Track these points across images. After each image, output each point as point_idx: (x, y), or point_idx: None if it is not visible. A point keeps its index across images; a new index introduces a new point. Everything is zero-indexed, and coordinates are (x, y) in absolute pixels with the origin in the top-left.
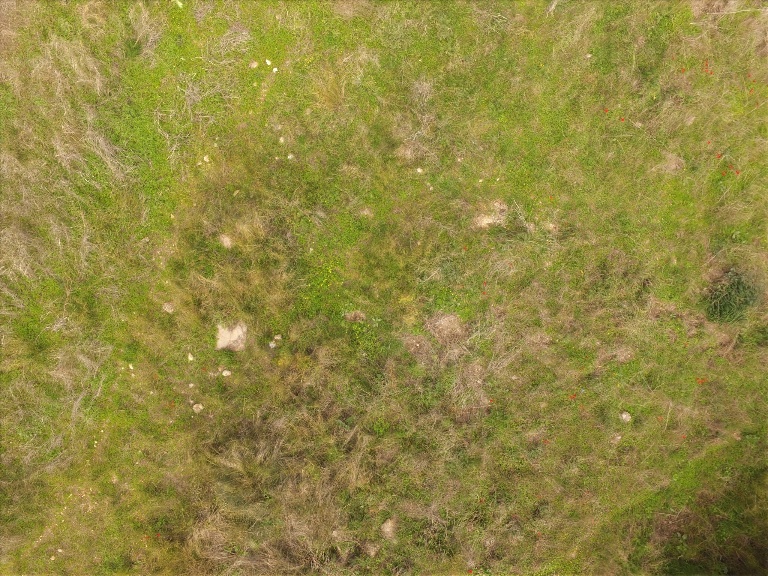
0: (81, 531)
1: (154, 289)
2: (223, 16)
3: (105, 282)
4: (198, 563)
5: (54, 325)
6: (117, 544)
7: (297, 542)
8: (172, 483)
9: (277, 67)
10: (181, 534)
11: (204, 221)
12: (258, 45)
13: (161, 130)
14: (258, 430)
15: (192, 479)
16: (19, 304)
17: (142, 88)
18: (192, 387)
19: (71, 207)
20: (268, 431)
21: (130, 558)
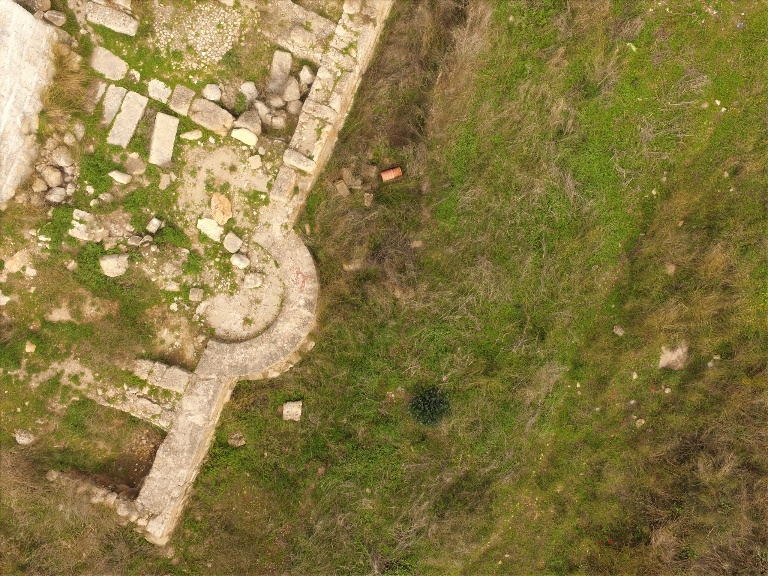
0: (528, 537)
1: (600, 313)
2: (680, 60)
3: (557, 306)
4: (665, 567)
5: (513, 347)
6: (561, 549)
7: (735, 547)
8: (613, 493)
9: (726, 107)
10: (633, 540)
11: (661, 250)
12: (711, 86)
13: (618, 165)
14: (709, 444)
15: (635, 489)
16: (478, 327)
17: (596, 126)
18: (633, 403)
19: (530, 237)
20: (718, 444)
21: (573, 562)
